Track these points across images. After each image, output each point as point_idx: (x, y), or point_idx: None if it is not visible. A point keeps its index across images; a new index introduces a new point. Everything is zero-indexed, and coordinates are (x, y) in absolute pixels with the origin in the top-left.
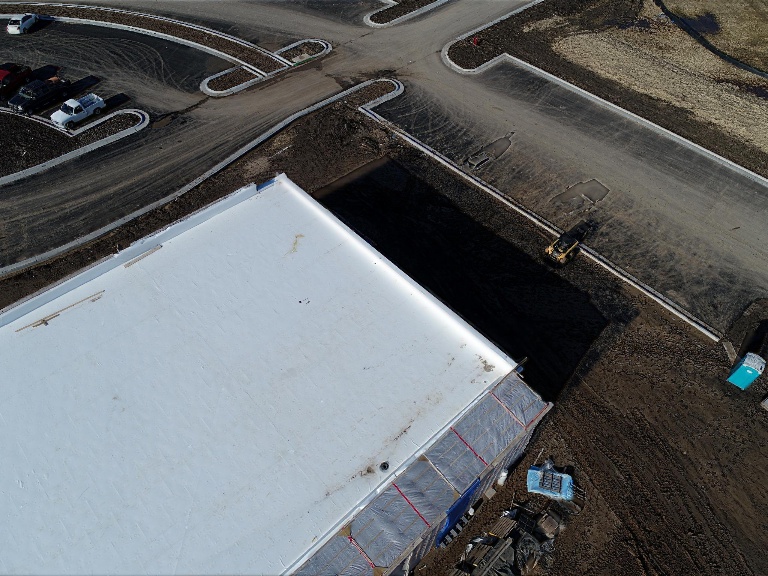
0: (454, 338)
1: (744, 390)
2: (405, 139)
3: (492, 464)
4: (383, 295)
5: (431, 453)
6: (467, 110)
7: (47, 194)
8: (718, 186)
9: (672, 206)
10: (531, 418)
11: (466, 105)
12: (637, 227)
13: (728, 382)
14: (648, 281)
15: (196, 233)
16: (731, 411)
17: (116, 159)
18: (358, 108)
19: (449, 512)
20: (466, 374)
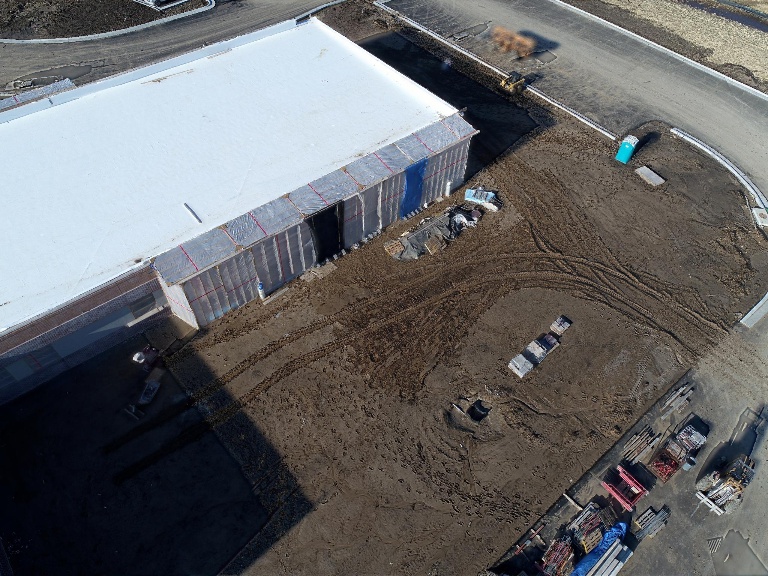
0: (422, 103)
1: (626, 164)
2: (407, 22)
3: (436, 152)
4: (378, 81)
5: (398, 143)
6: (457, 7)
7: (144, 42)
8: (641, 58)
9: (602, 68)
10: (464, 135)
11: (457, 4)
12: (573, 78)
13: (615, 160)
14: (573, 107)
15: (254, 45)
16: (613, 174)
17: (192, 25)
18: (373, 2)
19: (406, 169)
20: (427, 119)
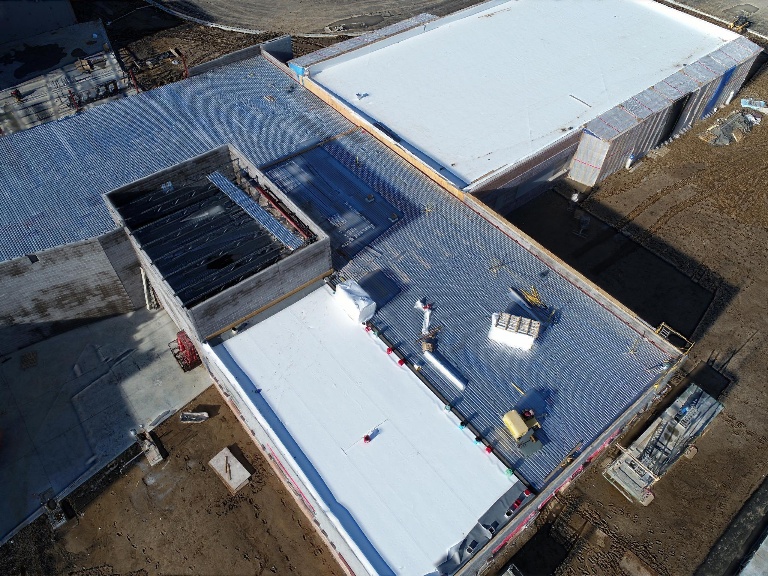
0: (703, 31)
1: None
2: None
3: (740, 63)
4: (658, 16)
5: (711, 55)
6: None
7: None
8: None
9: None
10: (755, 51)
11: None
12: None
13: None
14: None
15: None
16: None
17: None
18: None
19: (725, 73)
20: (714, 42)
